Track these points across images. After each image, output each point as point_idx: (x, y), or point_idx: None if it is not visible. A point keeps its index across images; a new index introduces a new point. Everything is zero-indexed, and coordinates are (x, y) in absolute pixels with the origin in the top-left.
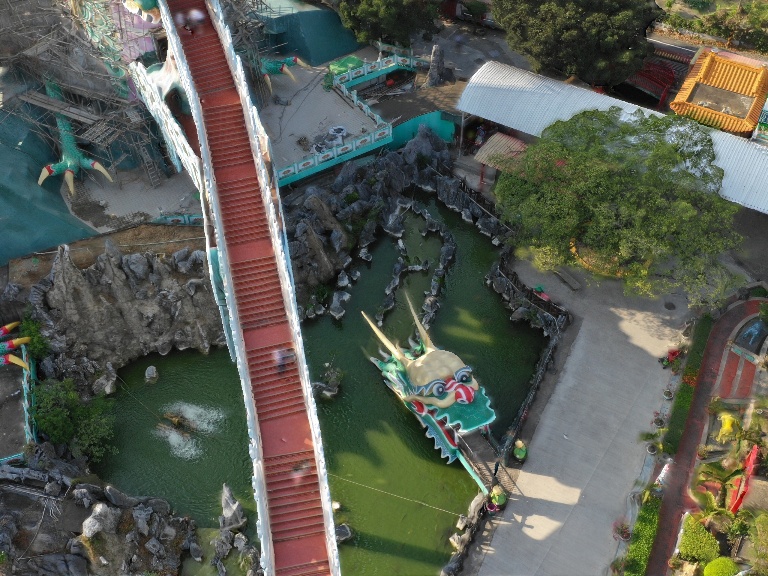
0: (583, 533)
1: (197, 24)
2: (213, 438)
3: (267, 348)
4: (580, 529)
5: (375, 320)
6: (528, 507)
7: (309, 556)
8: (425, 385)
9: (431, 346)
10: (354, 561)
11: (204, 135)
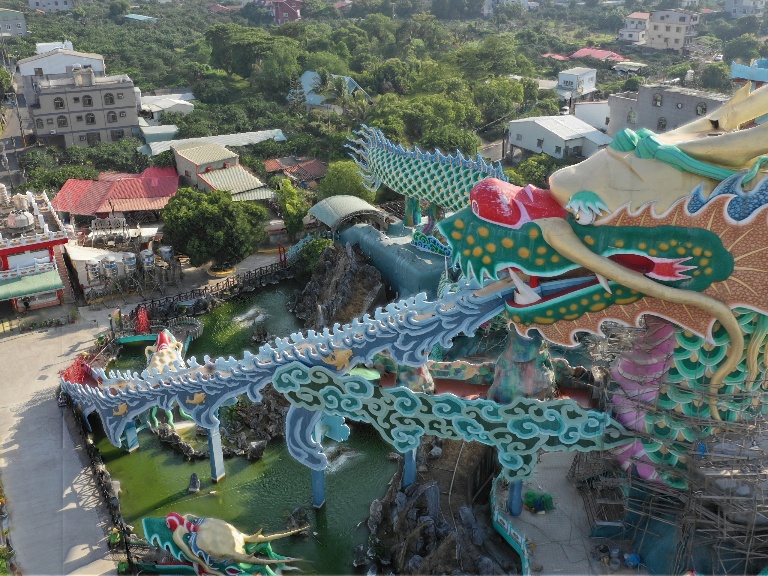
0: (47, 569)
1: None
2: None
3: None
4: (50, 569)
5: None
6: (94, 555)
7: None
8: None
9: (245, 555)
10: (177, 489)
11: None
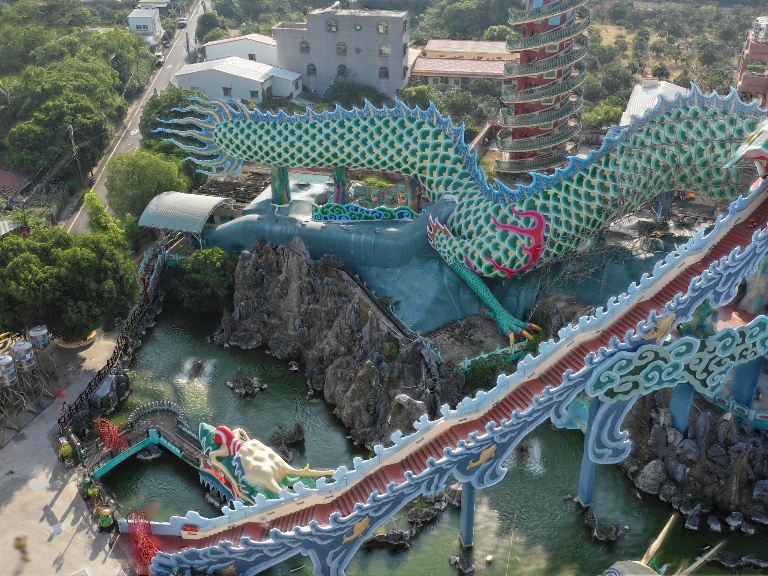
0: None
1: (764, 225)
2: (519, 471)
3: (531, 393)
4: None
5: (701, 553)
6: None
7: (396, 481)
8: (611, 567)
9: None
10: None
11: (665, 274)
